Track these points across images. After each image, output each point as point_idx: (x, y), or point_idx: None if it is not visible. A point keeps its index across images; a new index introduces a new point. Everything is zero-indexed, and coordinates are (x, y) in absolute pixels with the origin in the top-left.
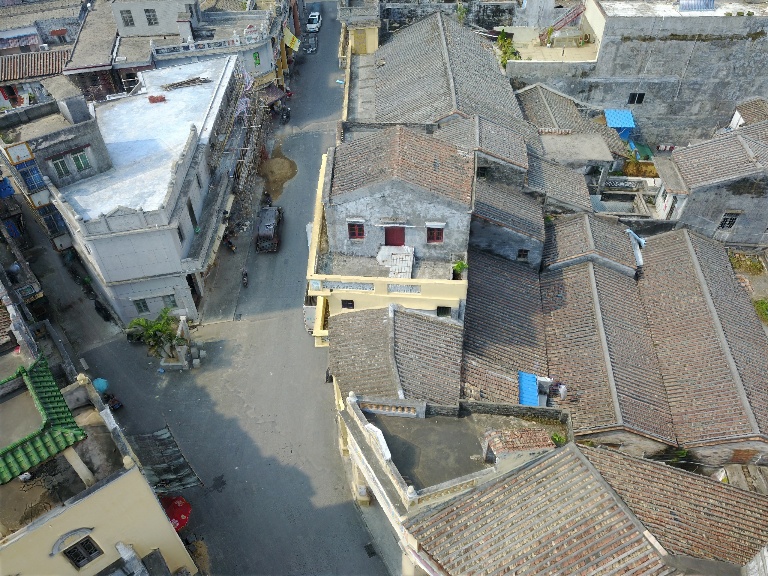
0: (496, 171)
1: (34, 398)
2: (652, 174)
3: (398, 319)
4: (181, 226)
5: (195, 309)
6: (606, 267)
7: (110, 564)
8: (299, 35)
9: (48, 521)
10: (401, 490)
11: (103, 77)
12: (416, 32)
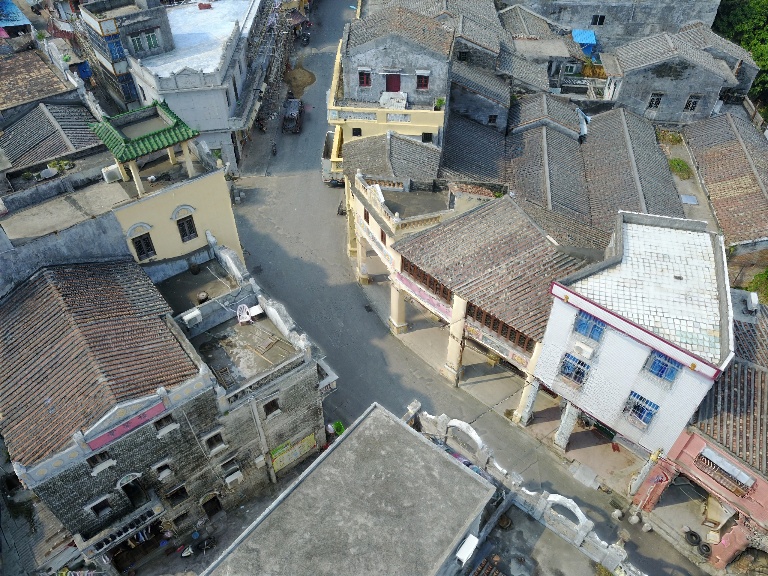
0: (474, 55)
1: (166, 114)
2: (605, 76)
3: (393, 141)
4: (228, 93)
5: (236, 164)
6: (556, 131)
7: (201, 247)
8: None
9: (173, 190)
10: (391, 221)
11: None
12: None
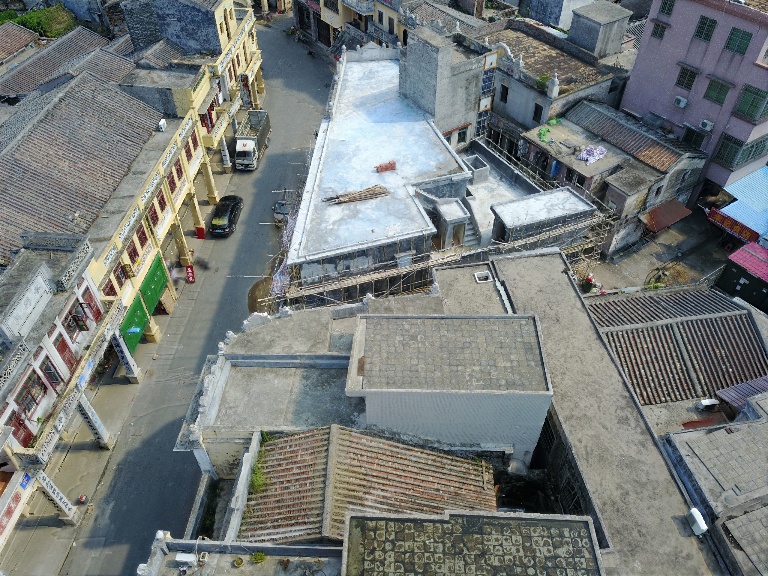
0: None
1: None
2: None
3: None
4: None
5: None
6: None
7: None
8: None
9: None
10: None
11: None
12: None
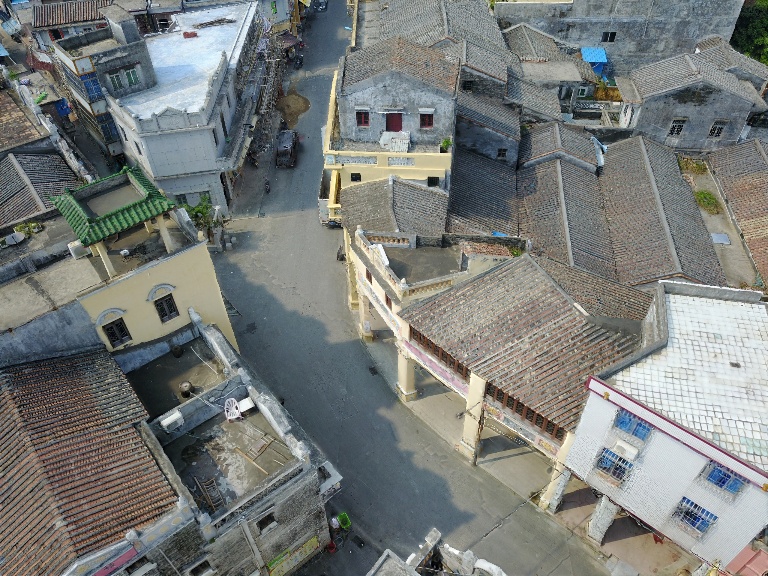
0: (480, 84)
1: (138, 183)
2: (619, 98)
3: (396, 186)
4: (216, 132)
5: (226, 206)
6: (571, 164)
7: (183, 326)
8: None
9: (148, 269)
10: (396, 286)
11: (140, 21)
12: None
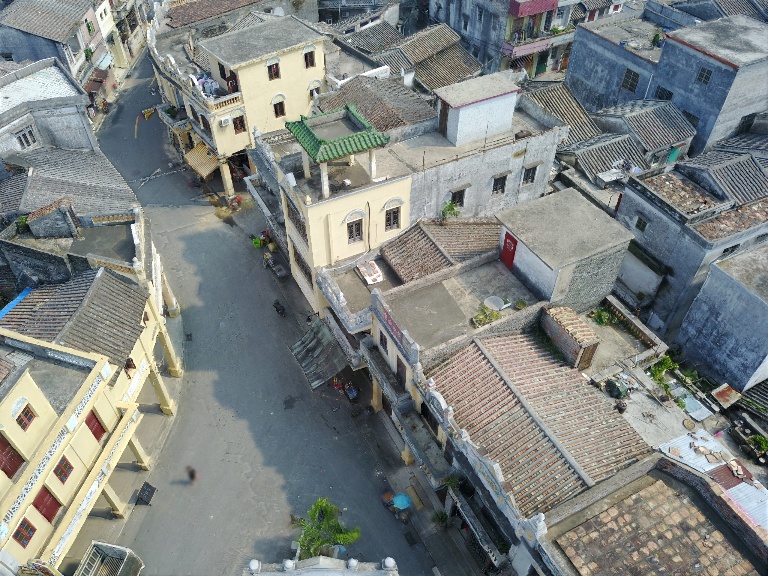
0: None
1: None
2: None
3: None
4: None
5: None
6: None
7: None
8: None
9: None
10: None
11: None
12: None
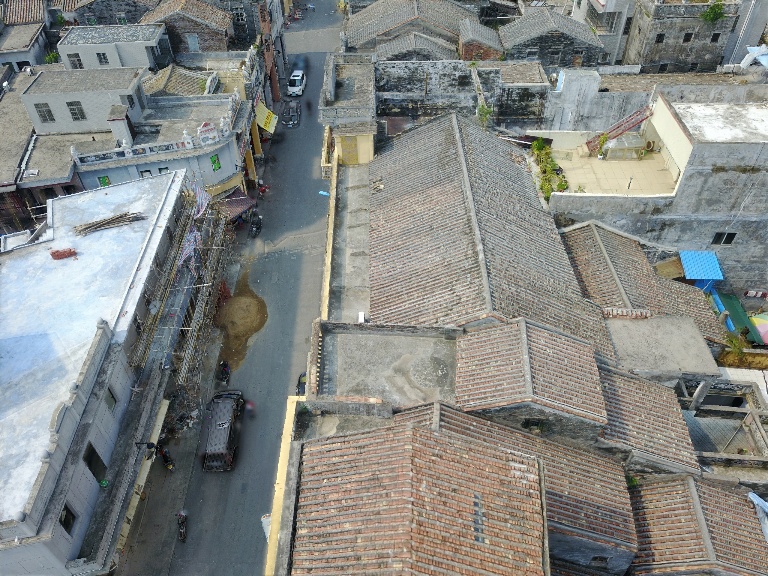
0: (557, 423)
1: None
2: (760, 365)
3: None
4: (70, 504)
5: None
6: None
7: None
8: (278, 100)
9: None
10: None
11: (5, 200)
12: (424, 141)
